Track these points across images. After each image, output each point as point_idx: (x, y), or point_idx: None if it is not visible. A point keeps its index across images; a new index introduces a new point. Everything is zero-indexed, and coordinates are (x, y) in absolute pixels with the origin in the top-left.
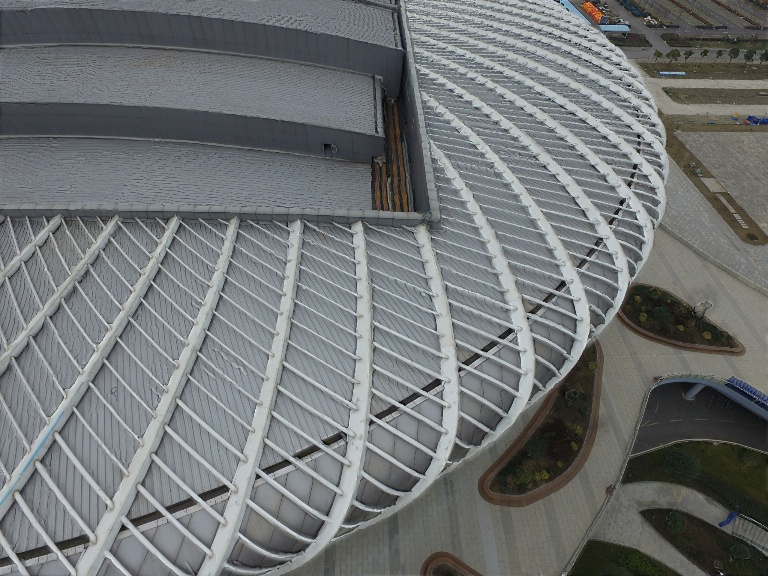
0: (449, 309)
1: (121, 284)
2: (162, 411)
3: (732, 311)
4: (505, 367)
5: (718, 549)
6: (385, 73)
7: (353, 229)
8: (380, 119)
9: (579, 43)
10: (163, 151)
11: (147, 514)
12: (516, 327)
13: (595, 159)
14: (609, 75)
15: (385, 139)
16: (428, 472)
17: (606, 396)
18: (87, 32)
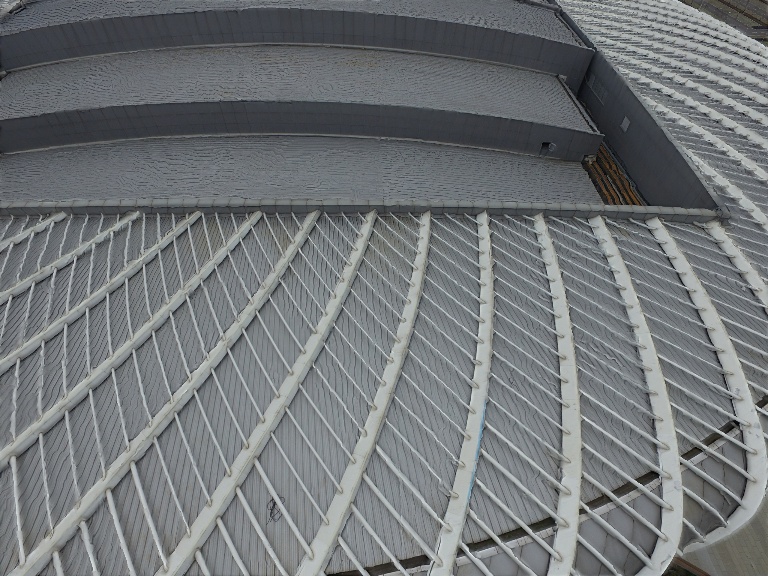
0: None
1: (465, 278)
2: (573, 400)
3: None
4: None
5: None
6: (570, 73)
7: (650, 225)
8: (588, 118)
9: (736, 43)
10: (392, 149)
11: (596, 499)
12: None
13: None
14: None
15: None
16: None
17: None
18: (291, 32)
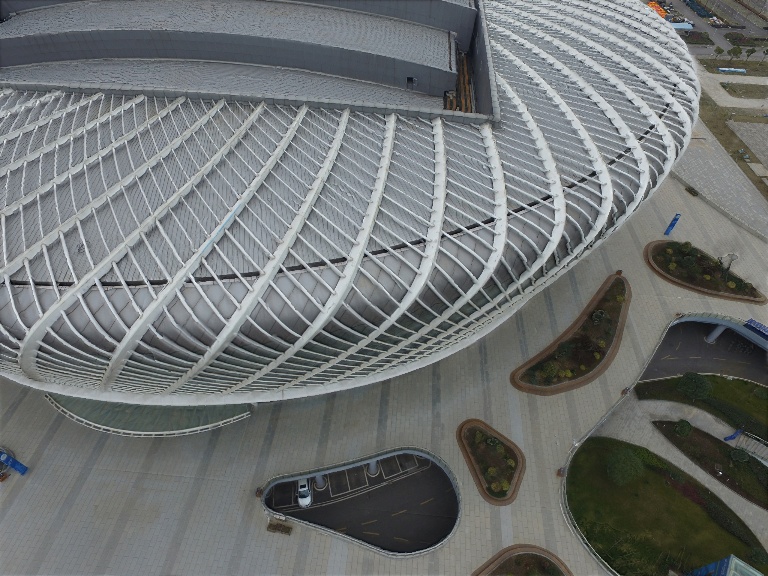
0: (503, 176)
1: (269, 142)
2: (303, 211)
3: (760, 270)
4: (542, 218)
5: (720, 455)
6: (459, 30)
7: (433, 123)
8: (454, 62)
9: (631, 15)
10: (283, 75)
11: (294, 266)
12: (553, 194)
13: (632, 95)
14: (655, 40)
15: (457, 76)
16: (480, 278)
17: (630, 324)
18: None
